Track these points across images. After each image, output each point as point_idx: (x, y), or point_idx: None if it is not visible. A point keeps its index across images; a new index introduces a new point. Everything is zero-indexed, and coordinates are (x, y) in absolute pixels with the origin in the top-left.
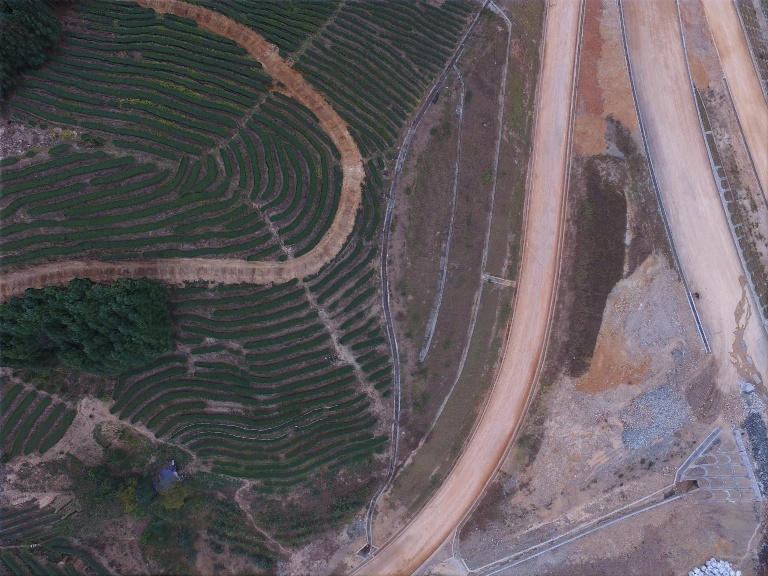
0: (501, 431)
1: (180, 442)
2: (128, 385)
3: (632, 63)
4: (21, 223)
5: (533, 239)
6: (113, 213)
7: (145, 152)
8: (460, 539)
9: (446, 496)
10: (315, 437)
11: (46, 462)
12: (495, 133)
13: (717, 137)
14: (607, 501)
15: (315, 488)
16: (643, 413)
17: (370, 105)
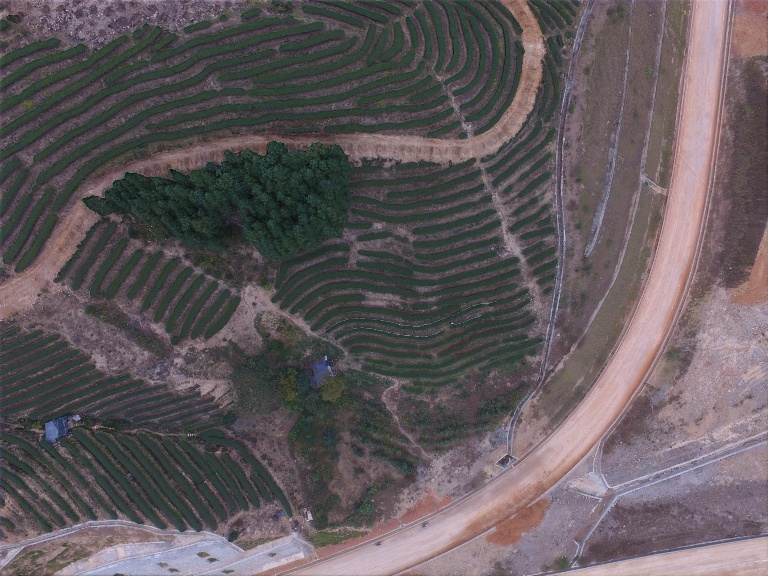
0: (648, 344)
1: (333, 337)
2: (288, 275)
3: None
4: (212, 90)
5: (685, 145)
6: (299, 83)
7: (333, 19)
8: (603, 452)
9: (589, 409)
10: (468, 337)
11: (210, 348)
12: (658, 26)
13: None
14: (756, 421)
15: (465, 390)
16: None
17: None
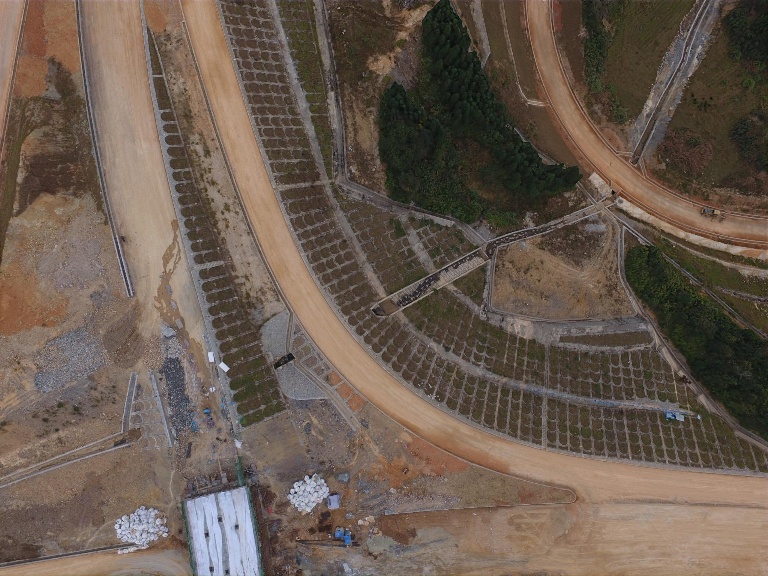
0: None
1: None
2: None
3: (83, 5)
4: None
5: None
6: None
7: None
8: None
9: None
10: None
11: None
12: None
13: (171, 81)
14: (44, 446)
15: None
16: (54, 355)
17: None
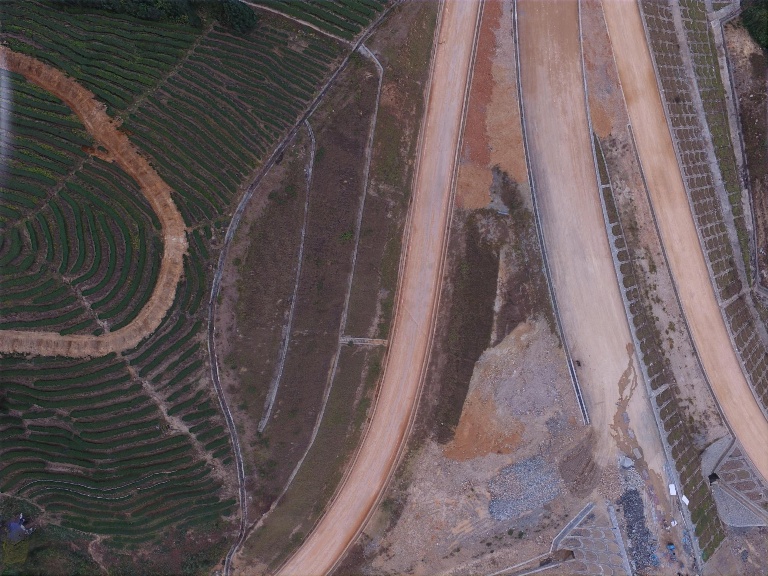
0: (366, 493)
1: (28, 496)
2: None
3: (526, 108)
4: None
5: (409, 296)
6: None
7: None
8: None
9: (308, 554)
10: (161, 498)
11: None
12: (359, 189)
13: (616, 190)
14: (477, 567)
15: (164, 546)
16: (511, 484)
17: (203, 168)
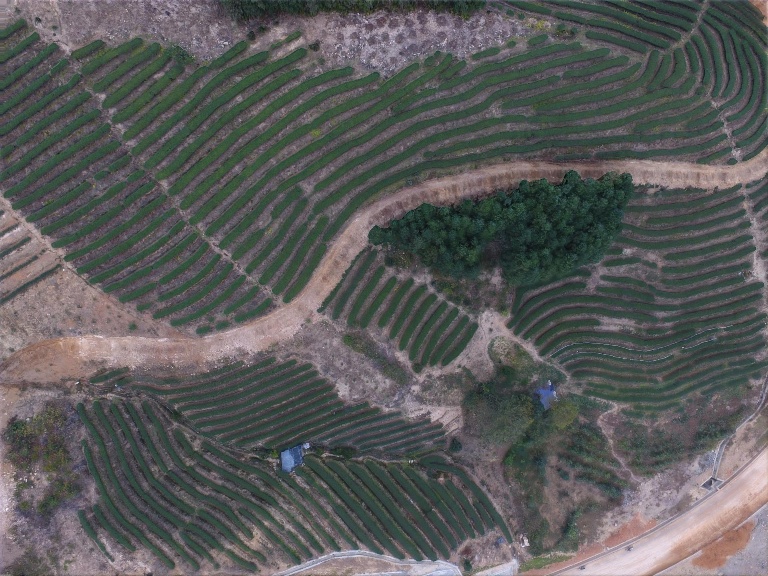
0: None
1: (557, 362)
2: (522, 300)
3: None
4: (494, 118)
5: None
6: (577, 110)
7: (615, 45)
8: None
9: None
10: (693, 360)
11: (445, 375)
12: None
13: None
14: None
15: (686, 414)
16: None
17: None
